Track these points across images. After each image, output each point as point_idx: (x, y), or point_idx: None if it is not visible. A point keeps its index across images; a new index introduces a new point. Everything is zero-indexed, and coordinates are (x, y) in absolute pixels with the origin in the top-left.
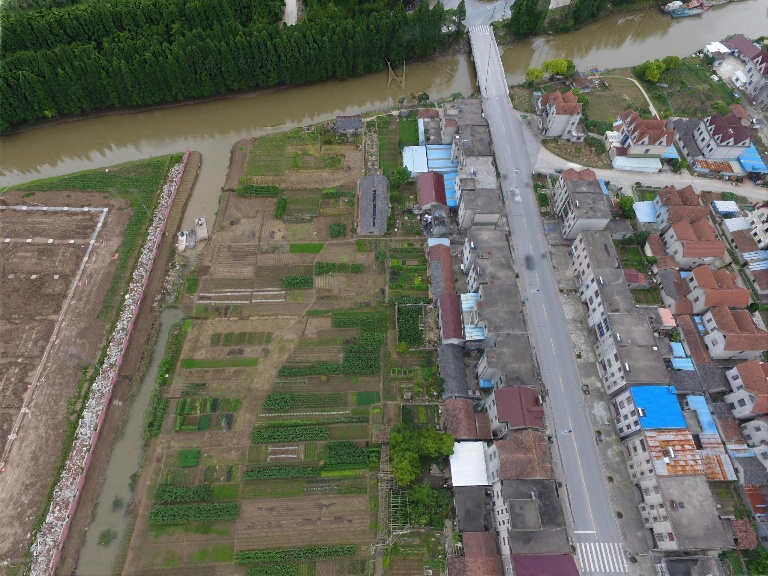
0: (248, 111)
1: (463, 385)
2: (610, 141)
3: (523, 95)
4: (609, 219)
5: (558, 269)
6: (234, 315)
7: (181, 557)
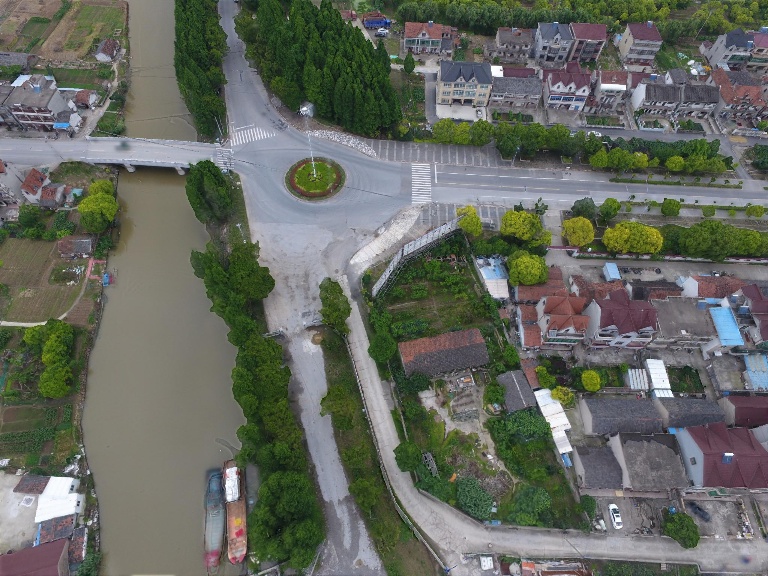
0: None
1: None
2: None
3: None
4: None
5: None
6: None
7: None
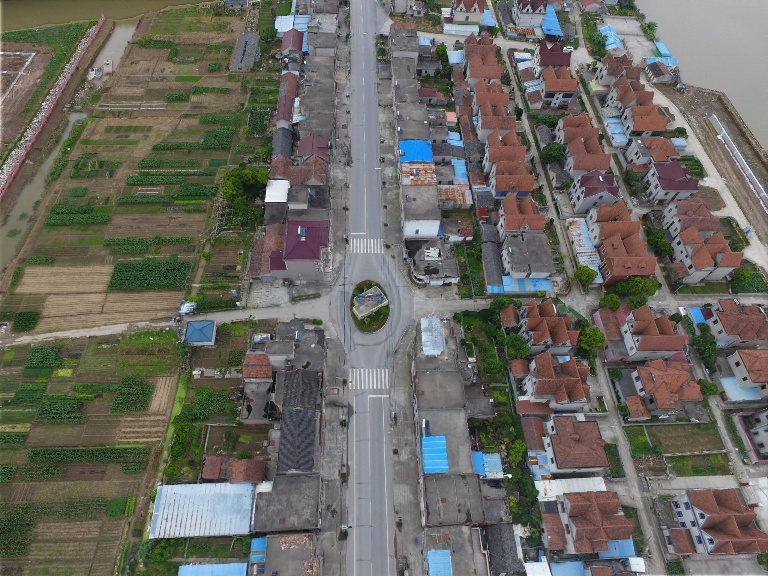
0: (161, 1)
1: (287, 151)
2: (443, 14)
3: None
4: (417, 52)
5: (381, 93)
6: (125, 116)
7: (65, 242)
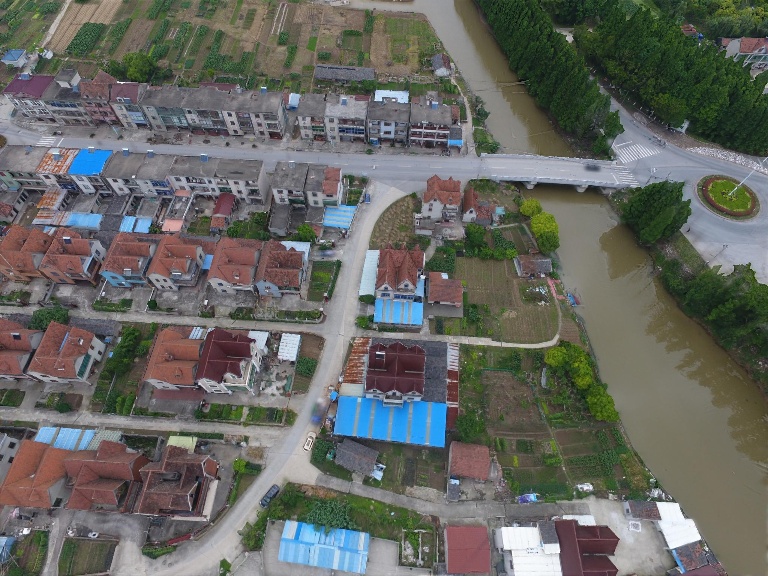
0: None
1: None
2: None
3: (504, 203)
4: None
5: None
6: None
7: (141, 5)
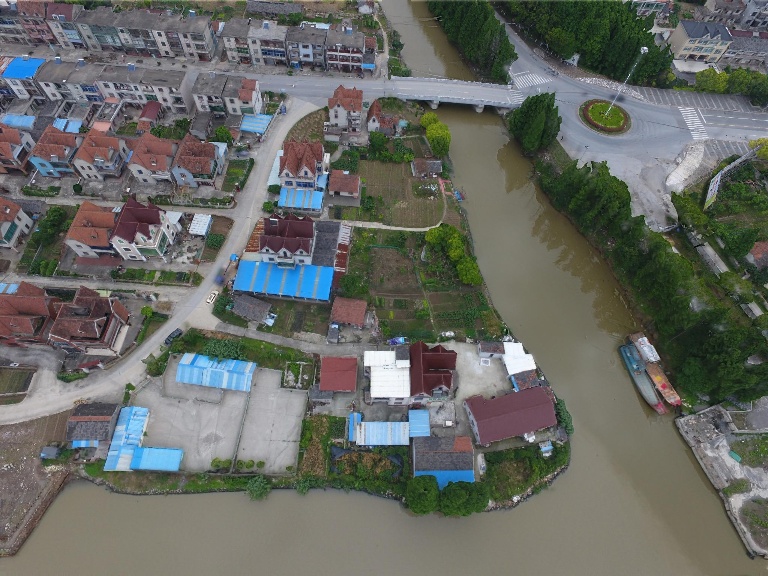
0: None
1: None
2: None
3: (408, 119)
4: None
5: None
6: None
7: None
